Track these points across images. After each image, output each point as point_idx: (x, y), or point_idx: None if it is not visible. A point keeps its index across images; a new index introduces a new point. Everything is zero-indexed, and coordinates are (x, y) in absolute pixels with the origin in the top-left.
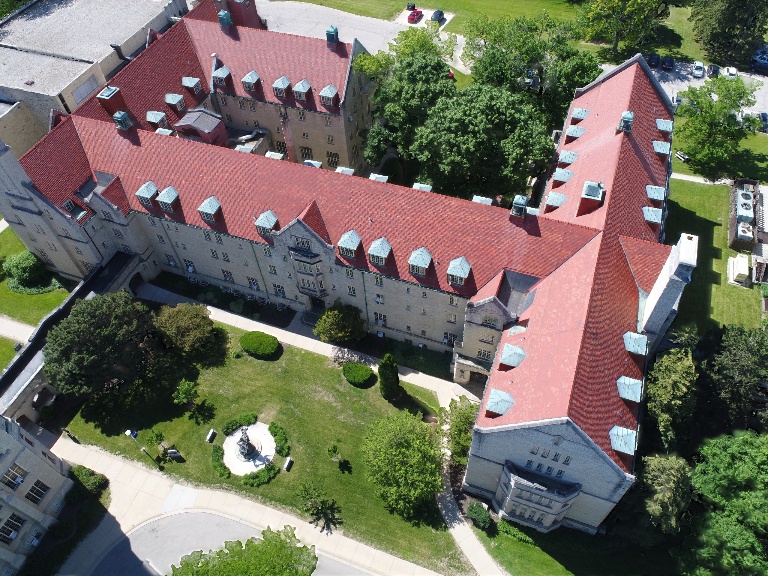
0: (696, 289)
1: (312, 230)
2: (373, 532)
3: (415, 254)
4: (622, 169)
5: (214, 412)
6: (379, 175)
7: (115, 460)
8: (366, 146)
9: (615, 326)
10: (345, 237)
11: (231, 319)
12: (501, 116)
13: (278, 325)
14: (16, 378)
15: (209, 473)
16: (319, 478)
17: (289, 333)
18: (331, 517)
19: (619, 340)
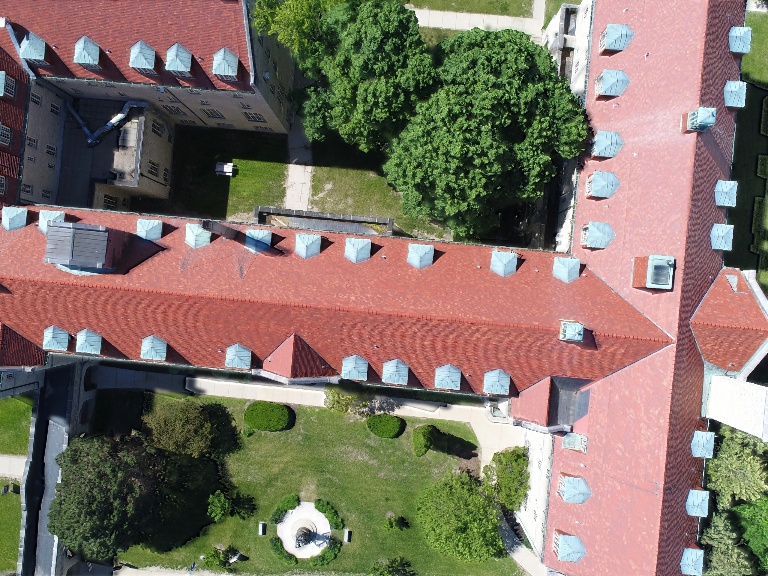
0: (736, 210)
1: (308, 380)
2: (444, 575)
3: (441, 375)
4: (694, 208)
5: (253, 503)
6: (358, 241)
7: (181, 575)
8: (304, 120)
9: (685, 446)
10: (348, 367)
11: (221, 389)
12: (512, 108)
13: (277, 383)
14: (36, 547)
15: (276, 564)
16: (381, 541)
17: (293, 390)
18: (403, 572)
19: (688, 456)
